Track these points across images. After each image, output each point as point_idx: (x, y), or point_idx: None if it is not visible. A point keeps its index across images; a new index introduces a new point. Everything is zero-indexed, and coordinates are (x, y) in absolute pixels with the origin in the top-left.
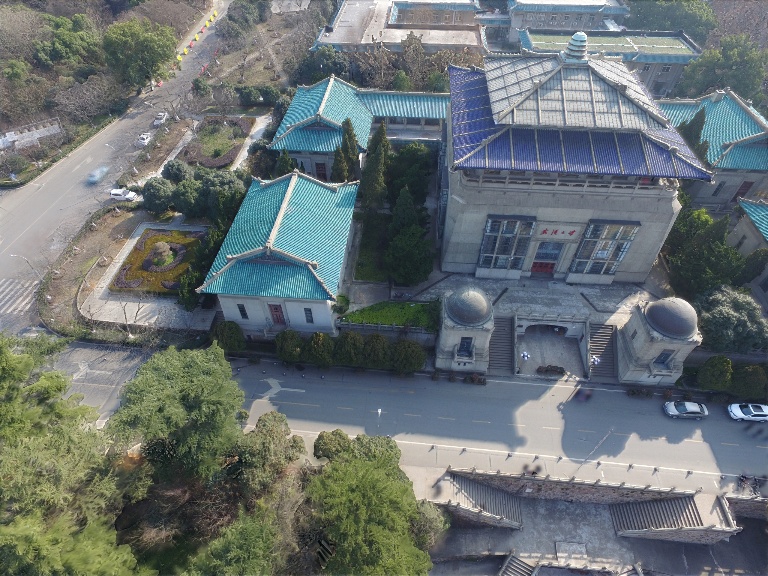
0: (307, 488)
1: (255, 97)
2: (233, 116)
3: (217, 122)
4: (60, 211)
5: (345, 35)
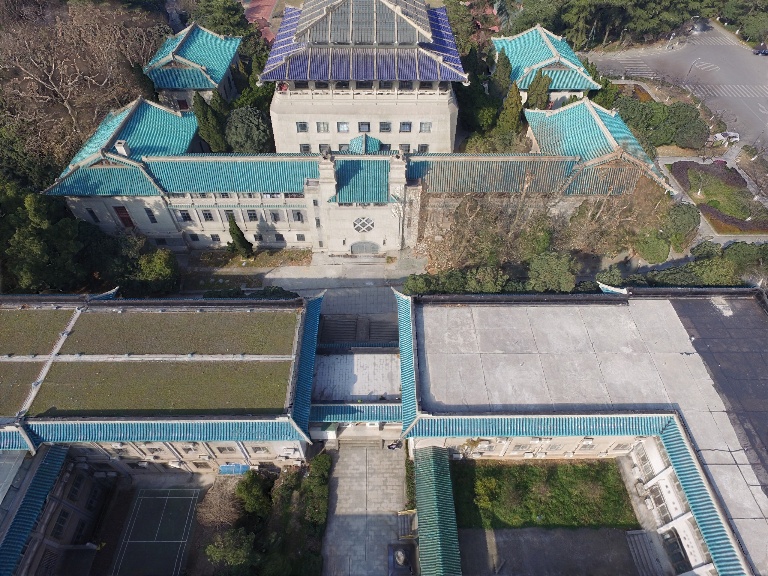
0: (476, 34)
1: (759, 250)
2: (761, 242)
3: (761, 220)
4: (761, 131)
5: (743, 352)
